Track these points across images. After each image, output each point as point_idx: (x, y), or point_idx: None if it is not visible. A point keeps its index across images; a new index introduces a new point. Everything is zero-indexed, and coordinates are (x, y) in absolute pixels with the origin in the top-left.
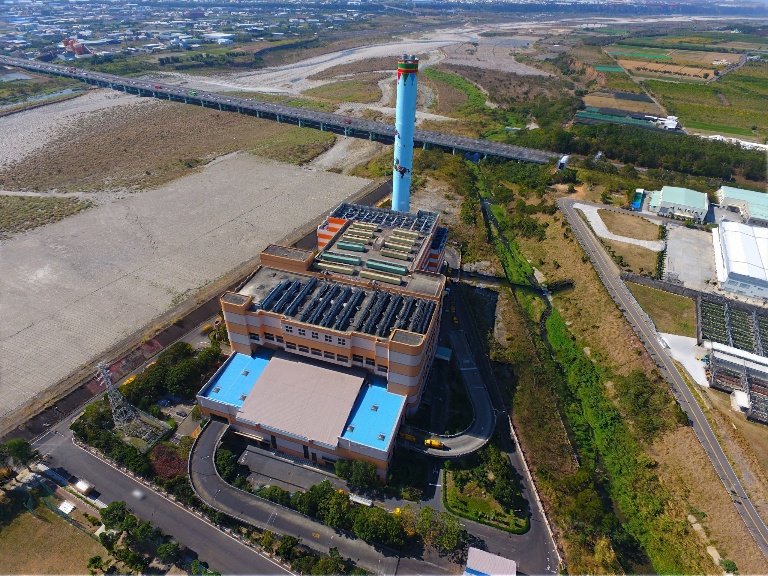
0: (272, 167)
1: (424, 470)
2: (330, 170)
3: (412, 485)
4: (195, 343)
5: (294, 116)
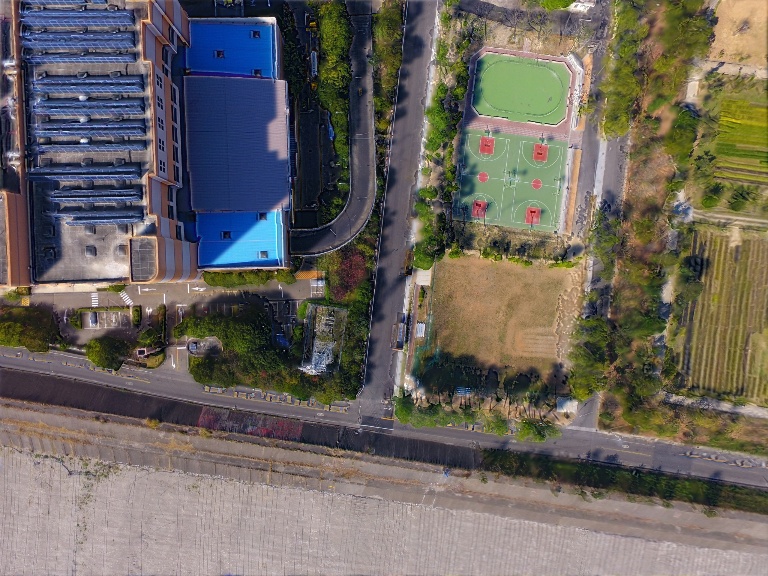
0: None
1: (256, 14)
2: None
3: (281, 16)
4: (179, 374)
5: None
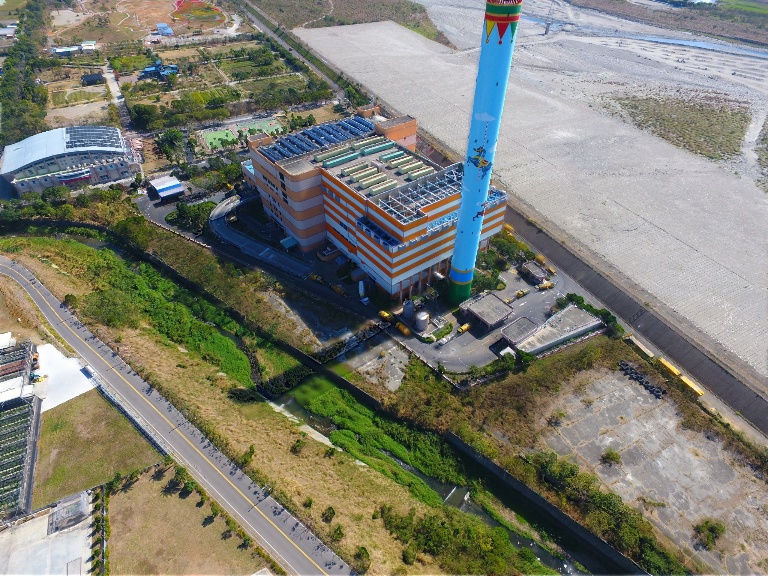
0: None
1: None
2: None
3: None
4: None
5: None
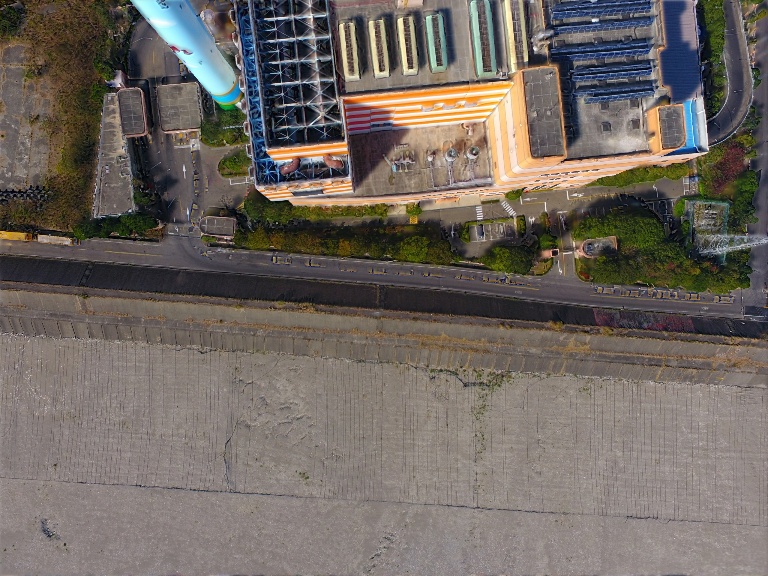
0: None
1: None
2: None
3: None
4: (567, 278)
5: None
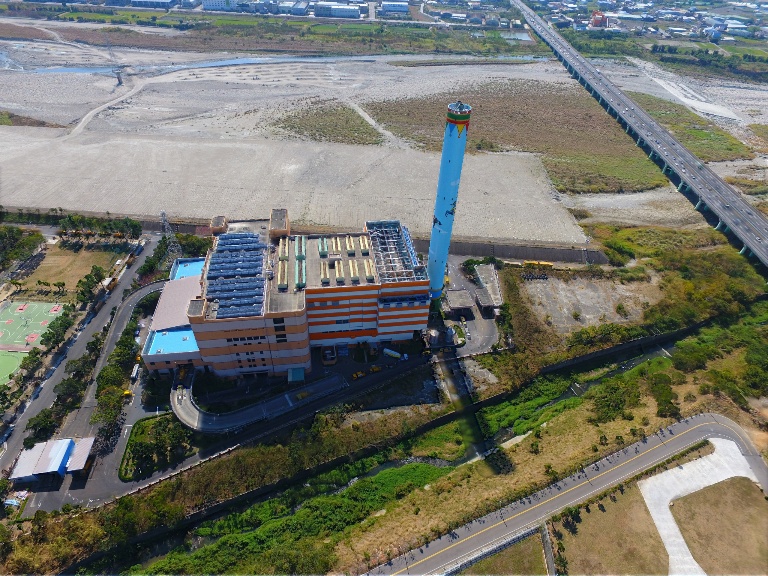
0: (530, 179)
1: (169, 400)
2: (573, 210)
3: None
4: None
5: (650, 144)
